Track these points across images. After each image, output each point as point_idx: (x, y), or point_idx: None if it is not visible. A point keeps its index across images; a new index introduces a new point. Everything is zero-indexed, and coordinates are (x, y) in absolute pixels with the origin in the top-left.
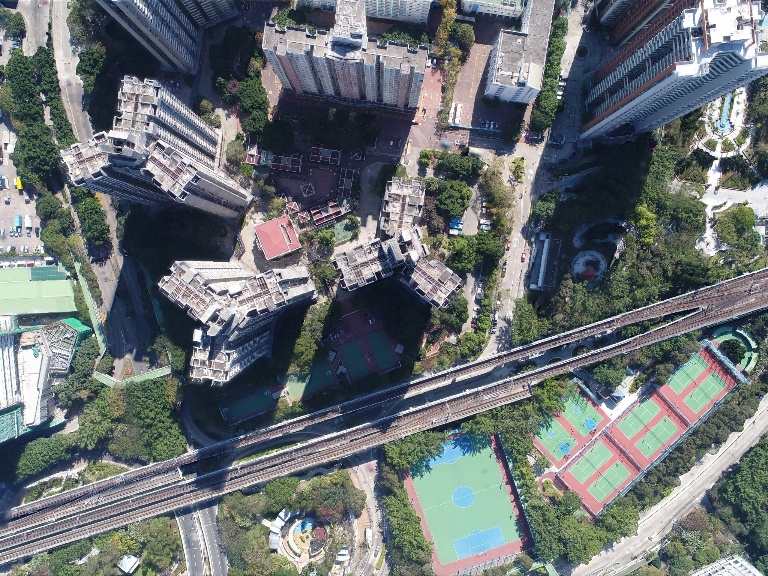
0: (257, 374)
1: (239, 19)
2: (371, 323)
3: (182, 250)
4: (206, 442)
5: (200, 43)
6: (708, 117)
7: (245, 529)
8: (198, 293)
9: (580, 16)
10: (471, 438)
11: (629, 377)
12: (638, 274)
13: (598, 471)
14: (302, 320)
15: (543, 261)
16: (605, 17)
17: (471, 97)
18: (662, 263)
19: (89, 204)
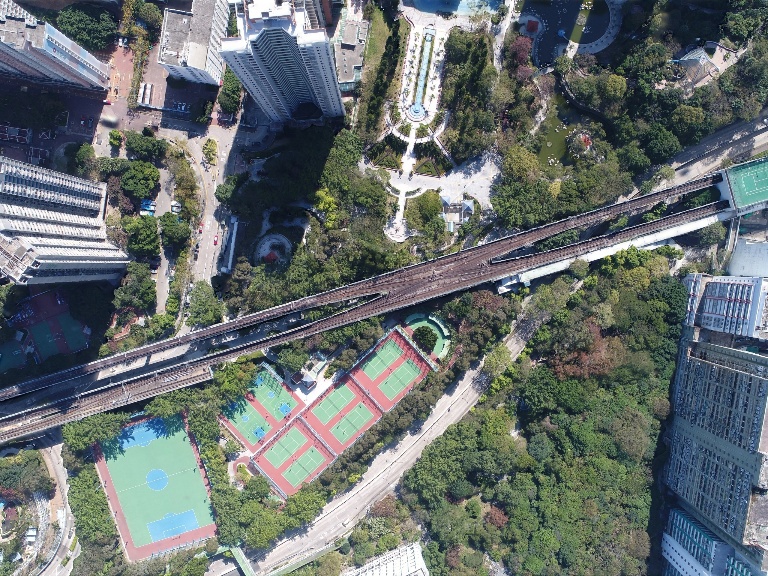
0: None
1: None
2: (60, 303)
3: None
4: None
5: None
6: (393, 102)
7: None
8: None
9: None
10: (165, 421)
11: (321, 362)
12: (313, 258)
13: (293, 456)
14: None
15: (233, 244)
16: None
17: (164, 78)
18: (344, 248)
19: None
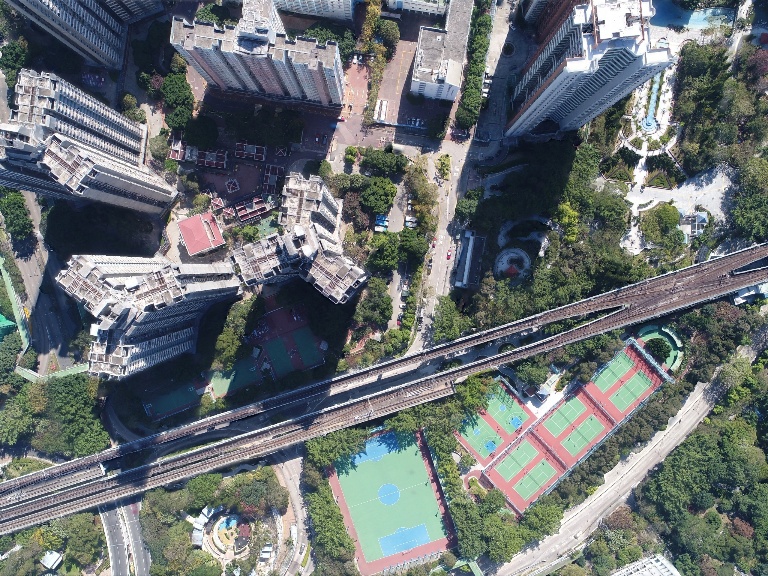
0: (180, 370)
1: (165, 14)
2: (296, 320)
3: (104, 245)
4: (131, 438)
5: (125, 38)
6: (632, 115)
7: (167, 525)
8: (95, 287)
9: (506, 14)
10: (397, 435)
11: (554, 375)
12: (559, 272)
13: (524, 469)
14: (225, 316)
15: (468, 258)
16: (528, 15)
17: (397, 94)
18: (585, 261)
19: (12, 199)
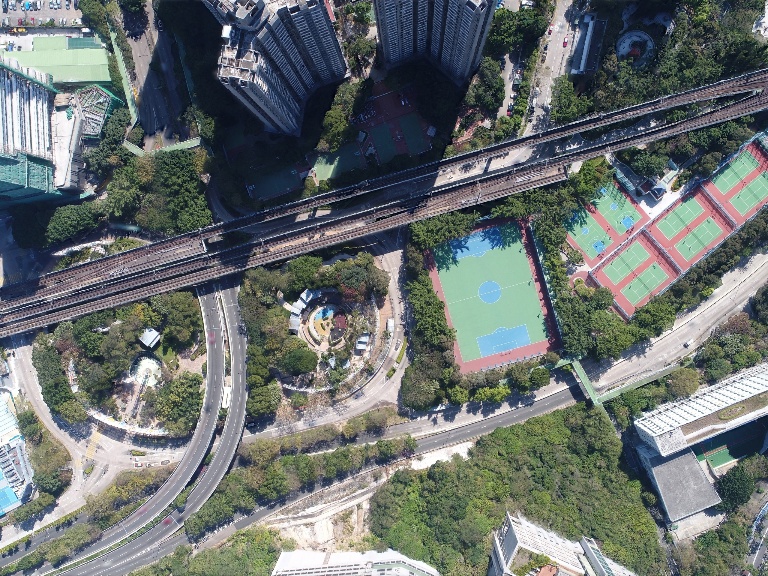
0: (285, 148)
1: None
2: (403, 104)
3: None
4: None
5: None
6: None
7: (266, 306)
8: None
9: None
10: (501, 231)
11: (672, 171)
12: (688, 49)
13: (633, 272)
14: (333, 95)
15: (586, 44)
16: None
17: None
18: (715, 43)
19: None
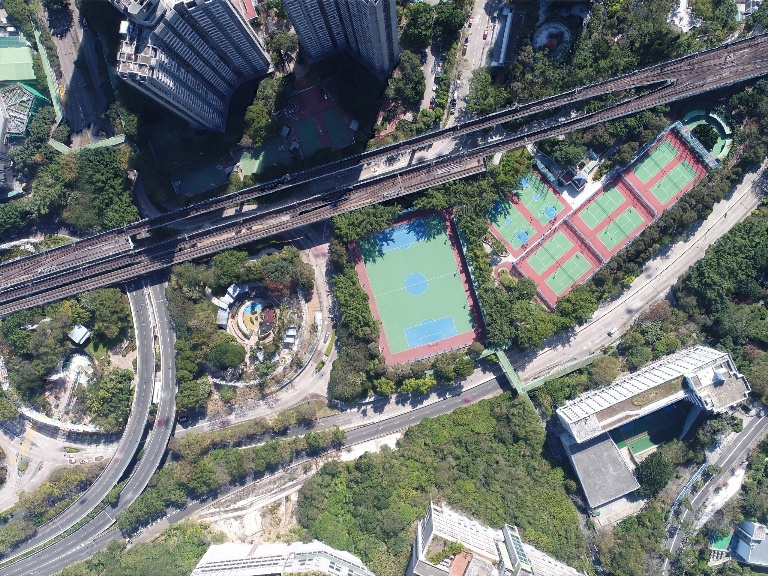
0: (209, 144)
1: None
2: (326, 98)
3: None
4: None
5: None
6: None
7: (193, 301)
8: None
9: None
10: (426, 223)
11: (592, 162)
12: (602, 40)
13: (557, 262)
14: (256, 91)
15: (505, 36)
16: None
17: None
18: (630, 34)
19: None
